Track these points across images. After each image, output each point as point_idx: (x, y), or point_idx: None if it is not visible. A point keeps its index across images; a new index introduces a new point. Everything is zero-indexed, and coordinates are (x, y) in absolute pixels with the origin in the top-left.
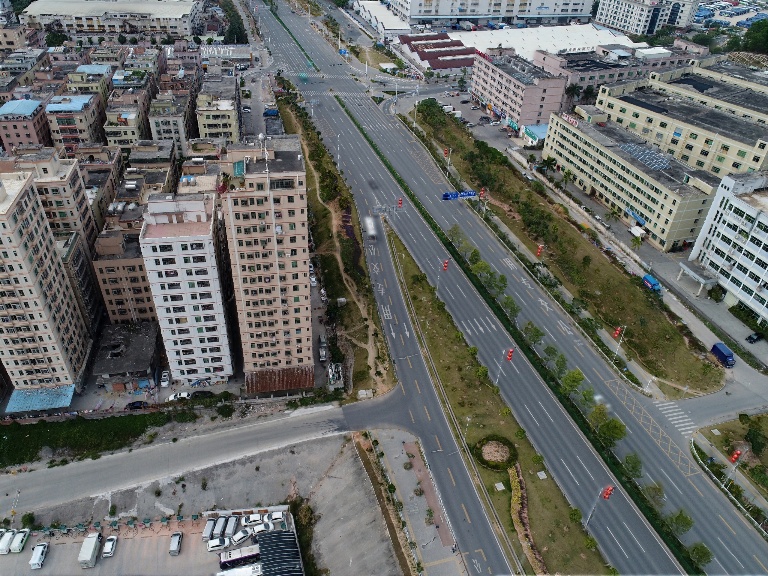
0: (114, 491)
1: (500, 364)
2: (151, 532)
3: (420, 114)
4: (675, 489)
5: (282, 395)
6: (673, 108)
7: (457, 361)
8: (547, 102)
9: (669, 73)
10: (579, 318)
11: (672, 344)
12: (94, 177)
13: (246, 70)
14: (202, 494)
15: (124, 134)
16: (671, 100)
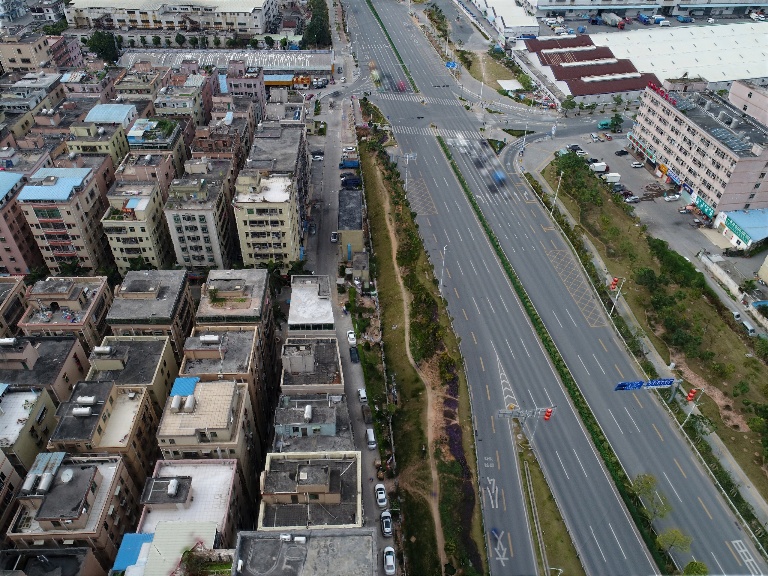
0: None
1: None
2: None
3: (558, 176)
4: None
5: None
6: None
7: None
8: (767, 180)
9: None
10: None
11: None
12: (48, 351)
13: (324, 88)
14: None
15: (130, 230)
16: None
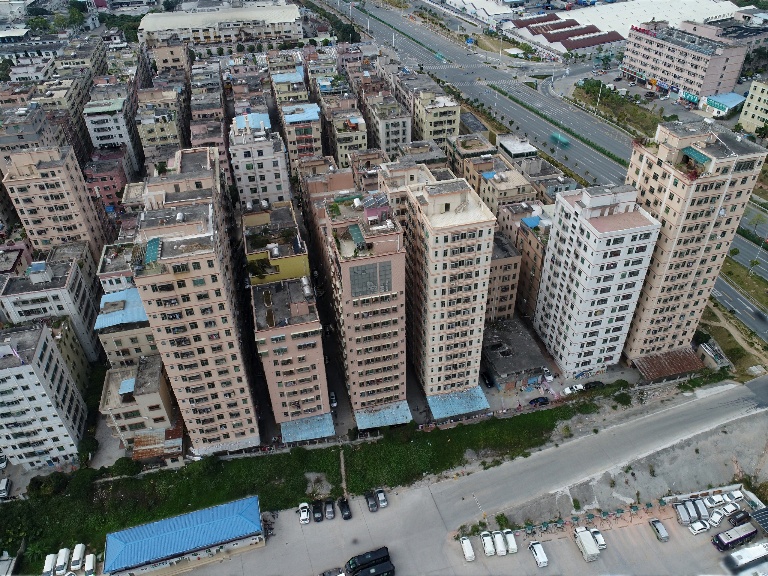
0: (570, 485)
1: None
2: (624, 522)
3: (586, 95)
4: None
5: (672, 379)
6: None
7: None
8: (727, 71)
9: None
10: None
11: None
12: None
13: None
14: (653, 481)
15: (355, 139)
16: None
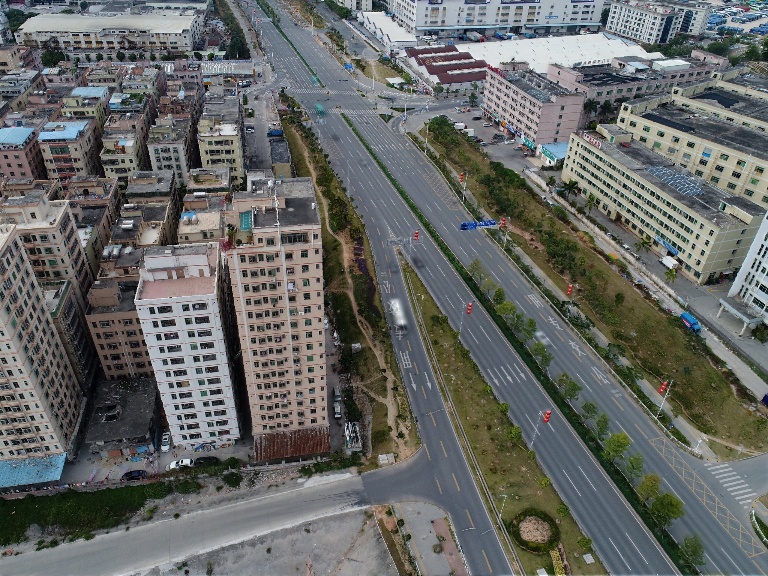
0: None
1: (533, 421)
2: None
3: (431, 132)
4: (739, 574)
5: (294, 460)
6: (700, 126)
7: (485, 418)
8: (565, 120)
9: (692, 88)
10: (615, 364)
11: (719, 394)
12: (89, 214)
13: (249, 87)
14: None
15: (121, 162)
16: (697, 117)
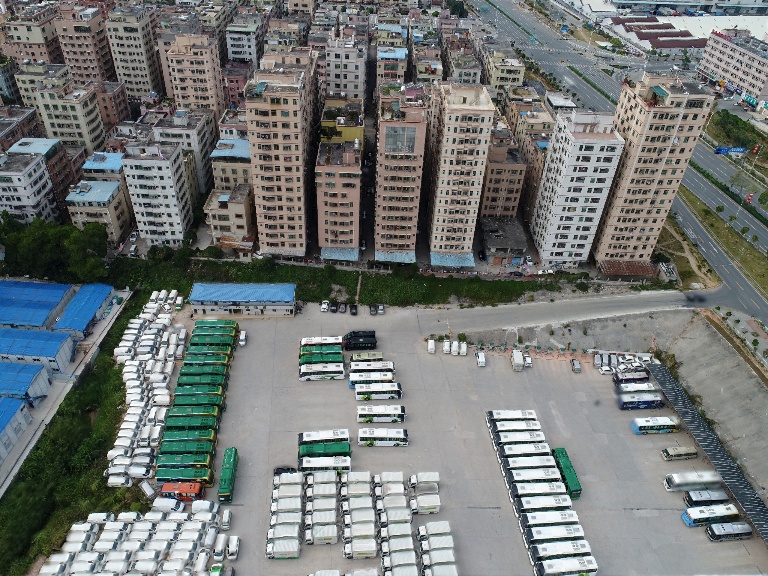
0: (519, 327)
1: None
2: (552, 357)
3: None
4: None
5: (627, 280)
6: None
7: None
8: None
9: None
10: None
11: None
12: None
13: None
14: (584, 338)
15: (432, 81)
16: None
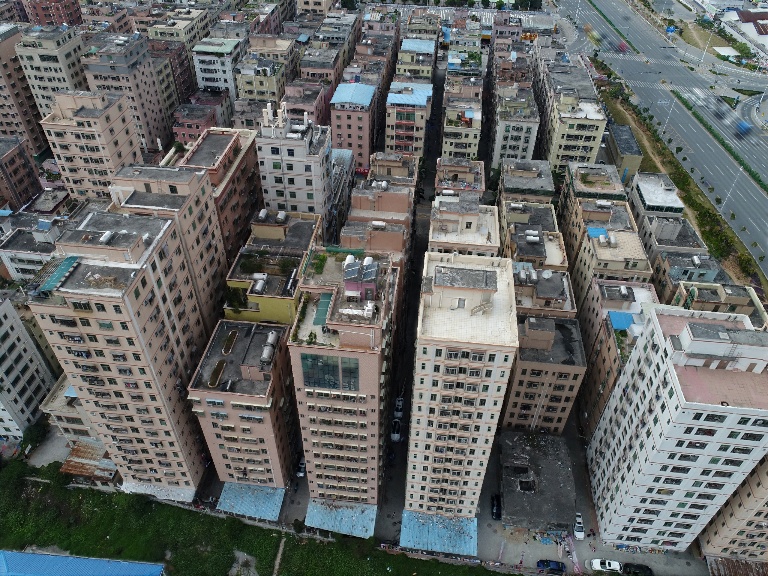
0: None
1: None
2: None
3: None
4: None
5: None
6: None
7: None
8: None
9: None
10: None
11: None
12: None
13: None
14: None
15: (464, 136)
16: None
